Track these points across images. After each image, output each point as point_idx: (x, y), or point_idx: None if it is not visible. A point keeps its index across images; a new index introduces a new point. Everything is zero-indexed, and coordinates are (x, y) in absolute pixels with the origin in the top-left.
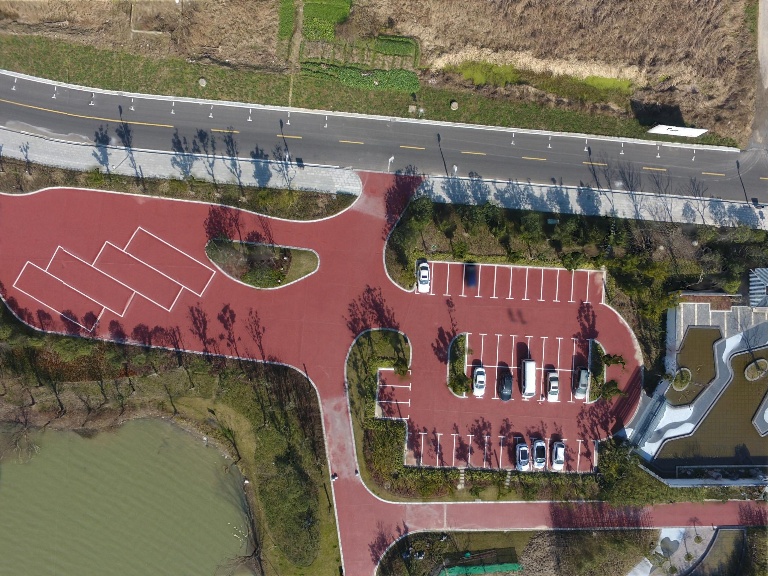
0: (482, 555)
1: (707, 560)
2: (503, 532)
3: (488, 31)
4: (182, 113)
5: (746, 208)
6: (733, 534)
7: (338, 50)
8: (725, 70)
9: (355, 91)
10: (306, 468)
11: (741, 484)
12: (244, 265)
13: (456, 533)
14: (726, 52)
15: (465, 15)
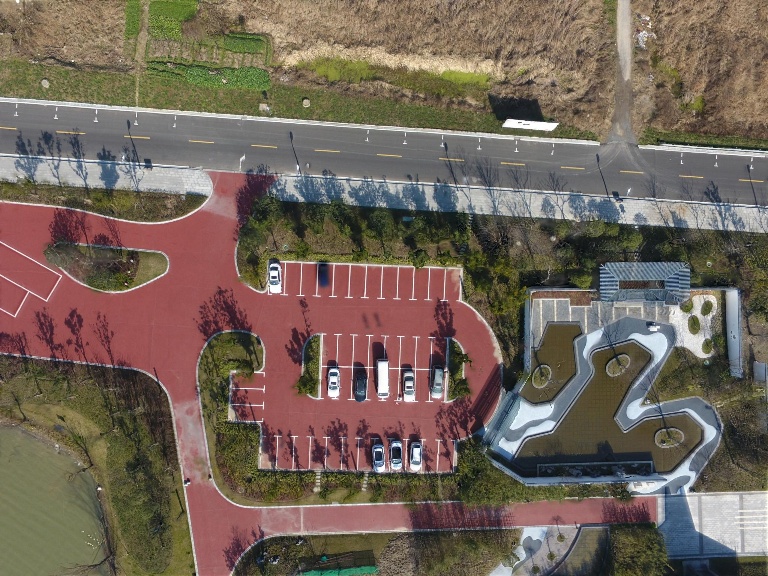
0: (339, 558)
1: (570, 559)
2: (361, 535)
3: (342, 27)
4: (26, 115)
5: (606, 202)
6: (596, 532)
7: (186, 48)
8: (583, 62)
9: (203, 90)
10: (157, 474)
11: (599, 481)
12: (90, 269)
13: (313, 537)
14: (585, 44)
15: (317, 11)
